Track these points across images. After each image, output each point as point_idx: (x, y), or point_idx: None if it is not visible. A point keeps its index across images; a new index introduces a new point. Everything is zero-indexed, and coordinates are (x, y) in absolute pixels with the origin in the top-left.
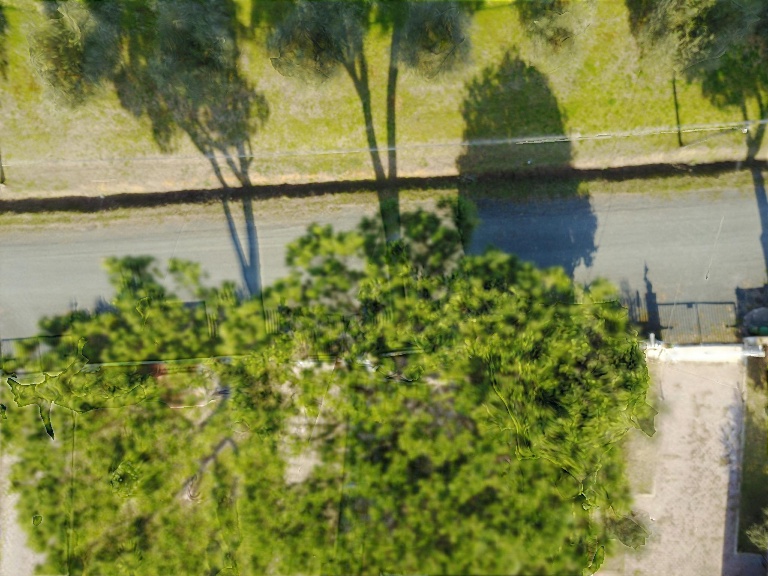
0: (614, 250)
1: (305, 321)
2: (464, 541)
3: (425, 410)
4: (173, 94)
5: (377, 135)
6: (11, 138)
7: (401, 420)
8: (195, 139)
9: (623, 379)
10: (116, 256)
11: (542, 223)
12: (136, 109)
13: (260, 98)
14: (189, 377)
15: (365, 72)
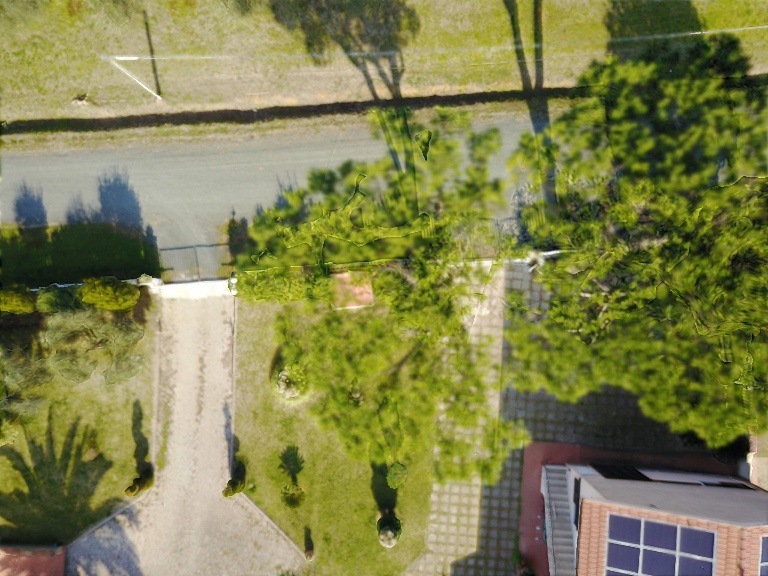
0: (756, 151)
1: (460, 225)
2: (621, 434)
3: None
4: (326, 8)
5: (525, 46)
6: (167, 52)
7: None
8: (348, 52)
9: None
10: (273, 165)
11: (687, 127)
12: (290, 23)
13: (411, 12)
14: (358, 276)
15: None
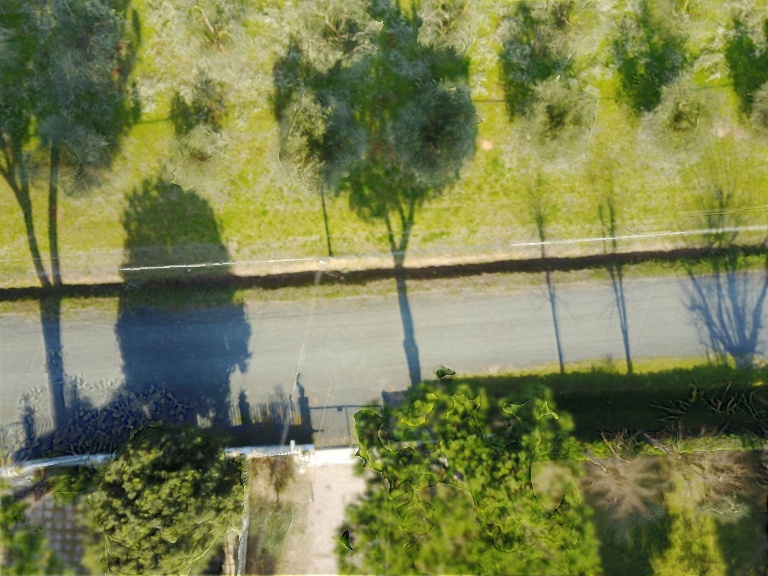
0: (267, 356)
1: None
2: None
3: (83, 517)
4: None
5: (39, 244)
6: None
7: (59, 528)
8: None
9: (171, 513)
10: None
11: (199, 330)
12: None
13: None
14: None
15: (26, 183)
